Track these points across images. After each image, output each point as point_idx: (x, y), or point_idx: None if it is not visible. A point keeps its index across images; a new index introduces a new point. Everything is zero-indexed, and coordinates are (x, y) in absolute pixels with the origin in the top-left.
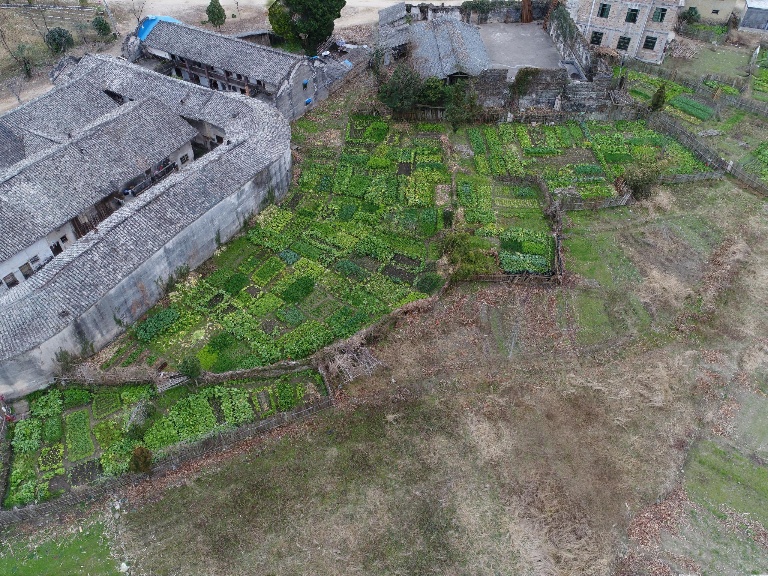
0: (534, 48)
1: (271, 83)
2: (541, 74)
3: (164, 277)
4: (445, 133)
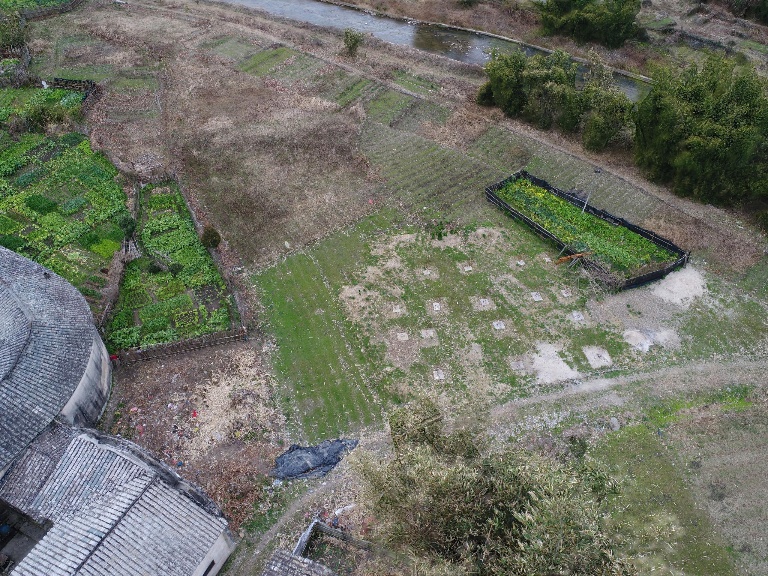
0: None
1: None
2: None
3: None
4: None
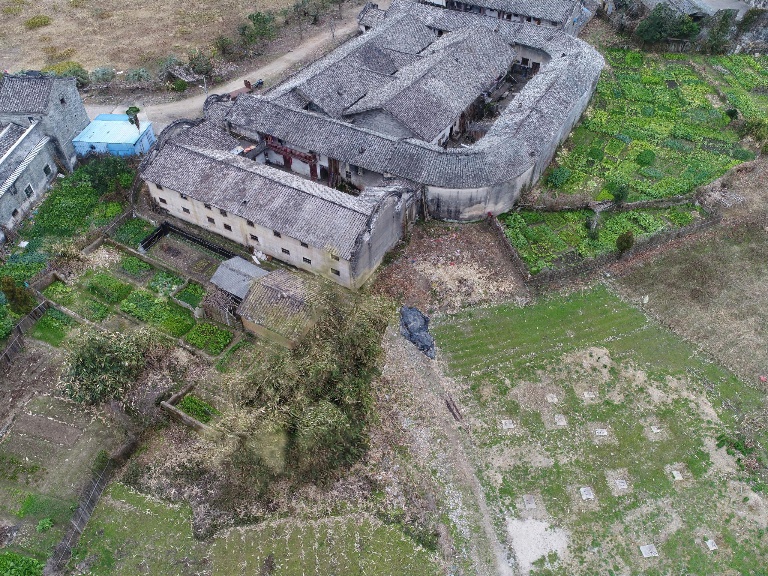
0: (726, 2)
1: (551, 20)
2: (765, 14)
3: (556, 144)
4: None
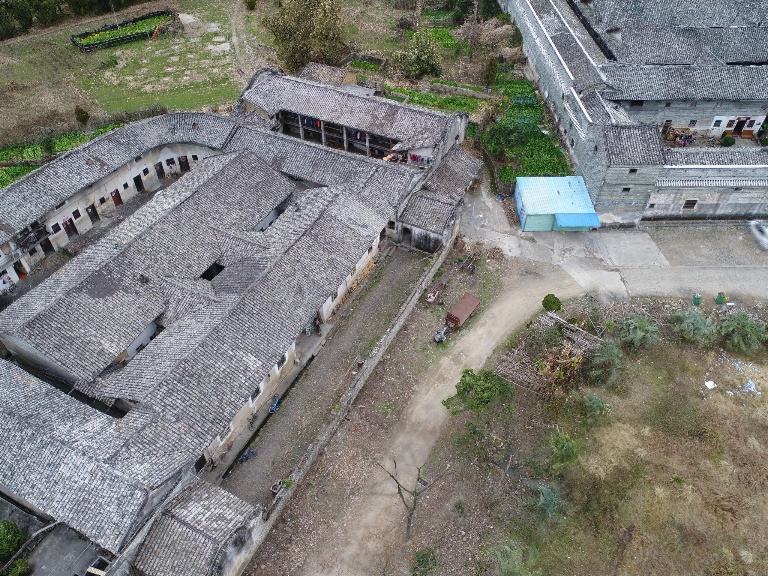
0: None
1: None
2: None
3: None
4: None
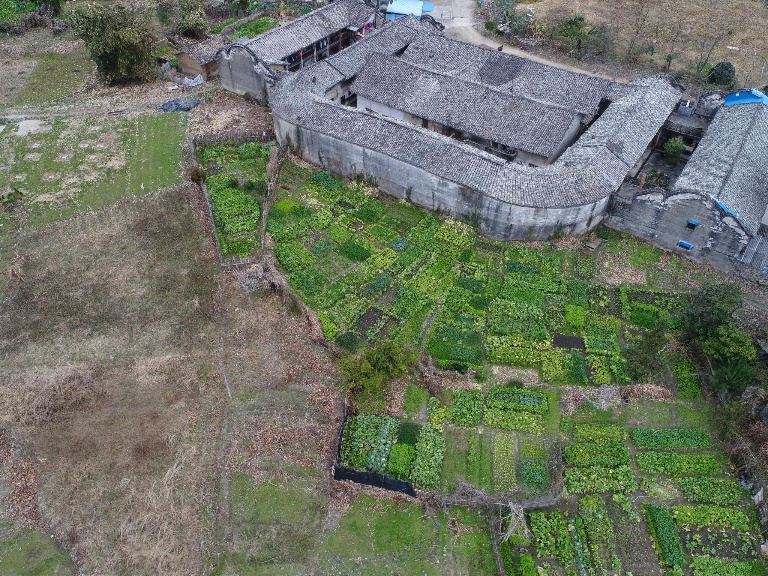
0: None
1: None
2: None
3: (358, 168)
4: (680, 398)
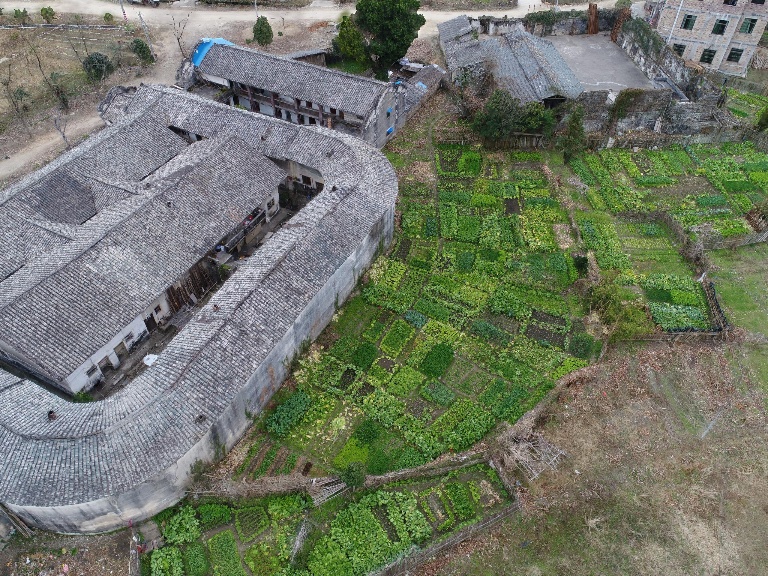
0: (610, 63)
1: (353, 113)
2: (644, 95)
3: (290, 355)
4: (544, 162)
